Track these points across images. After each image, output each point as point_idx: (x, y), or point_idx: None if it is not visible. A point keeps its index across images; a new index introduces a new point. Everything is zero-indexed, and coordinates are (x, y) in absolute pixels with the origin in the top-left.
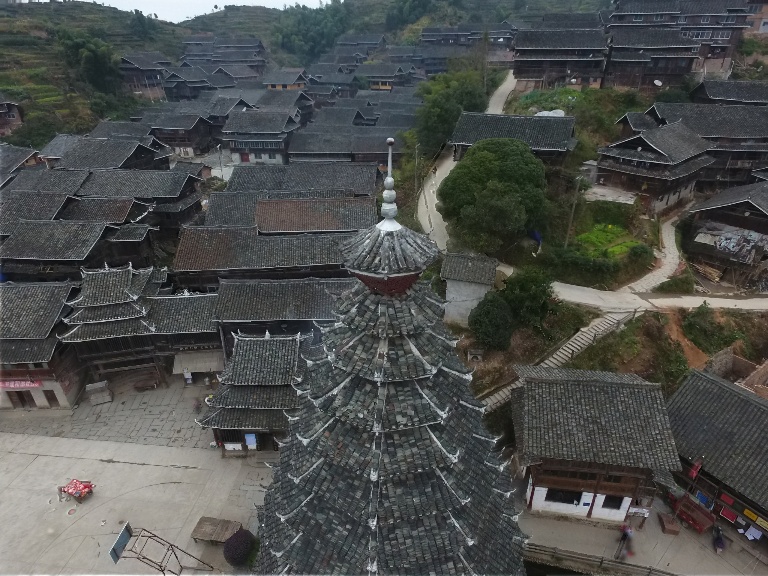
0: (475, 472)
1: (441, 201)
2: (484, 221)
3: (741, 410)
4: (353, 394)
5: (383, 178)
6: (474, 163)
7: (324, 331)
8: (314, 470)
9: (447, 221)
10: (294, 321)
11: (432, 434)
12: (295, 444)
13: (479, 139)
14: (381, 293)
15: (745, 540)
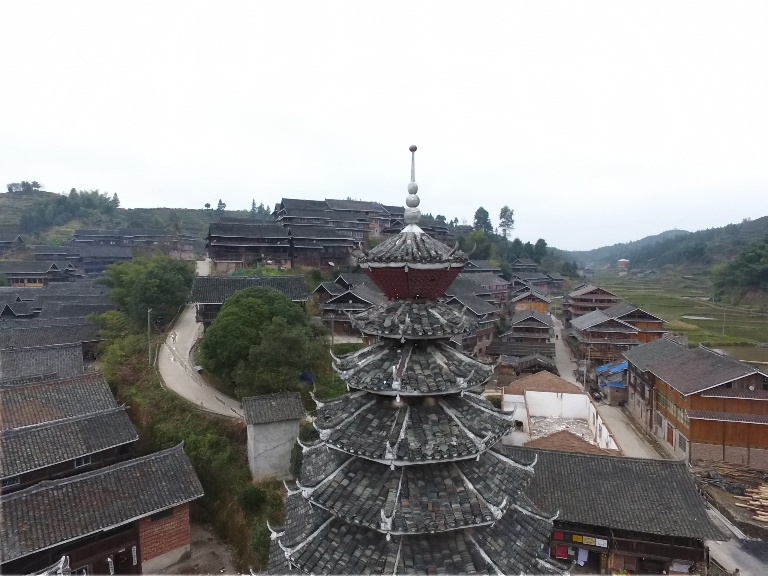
0: (524, 501)
1: (208, 354)
2: (280, 354)
3: (528, 459)
4: (423, 430)
5: (96, 357)
6: (242, 309)
7: (348, 375)
8: (398, 575)
9: (216, 376)
10: (22, 559)
11: (499, 455)
12: (327, 575)
13: (222, 298)
14: (421, 302)
15: (580, 569)
